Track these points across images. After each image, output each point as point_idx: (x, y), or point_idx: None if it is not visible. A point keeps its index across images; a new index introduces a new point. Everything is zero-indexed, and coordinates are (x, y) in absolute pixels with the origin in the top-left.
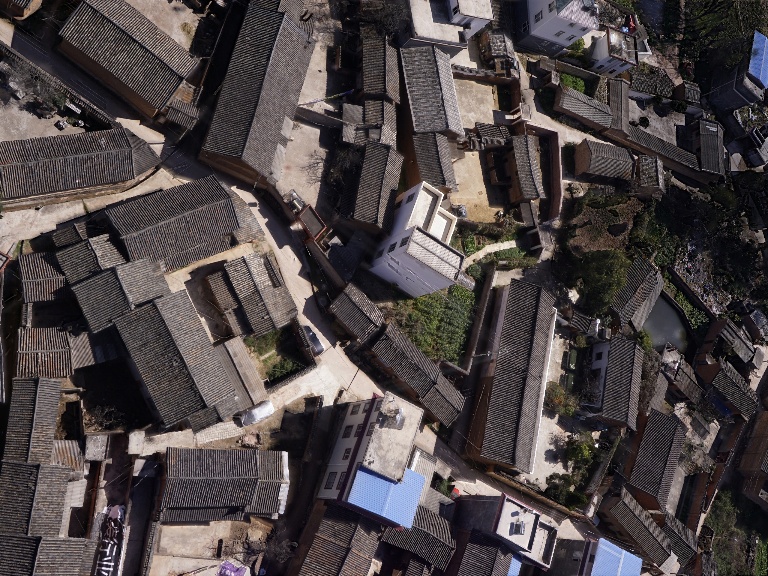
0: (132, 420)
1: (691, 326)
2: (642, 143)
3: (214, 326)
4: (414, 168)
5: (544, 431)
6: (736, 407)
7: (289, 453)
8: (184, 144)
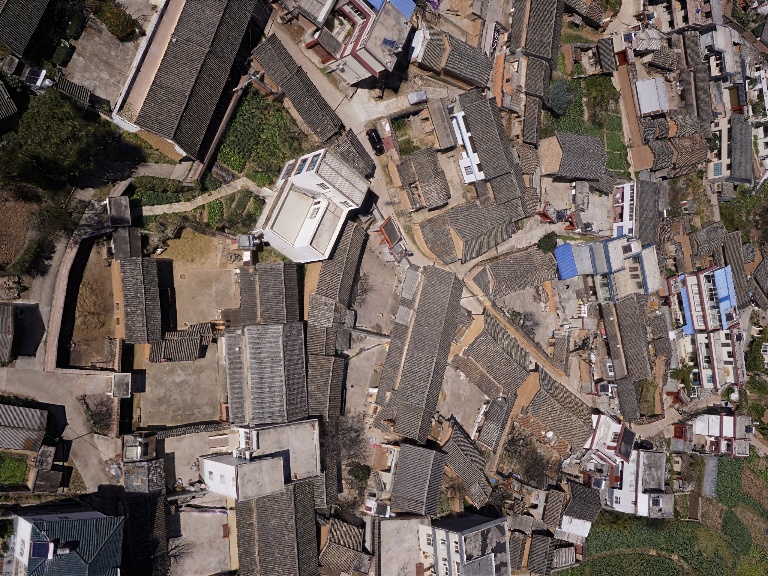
0: None
1: None
2: None
3: None
4: None
5: None
6: None
7: None
8: None
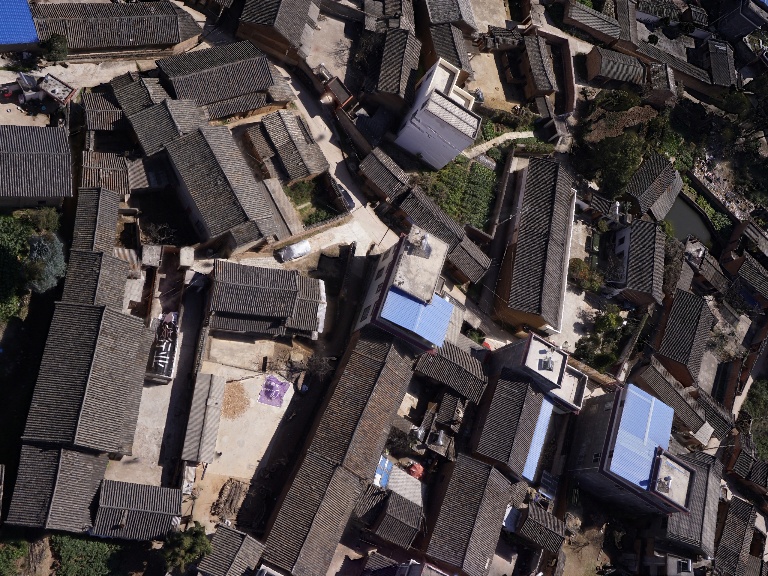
0: (183, 244)
1: (714, 228)
2: (652, 56)
3: (254, 175)
4: (432, 57)
5: (571, 305)
6: (764, 297)
7: (326, 291)
8: (223, 24)
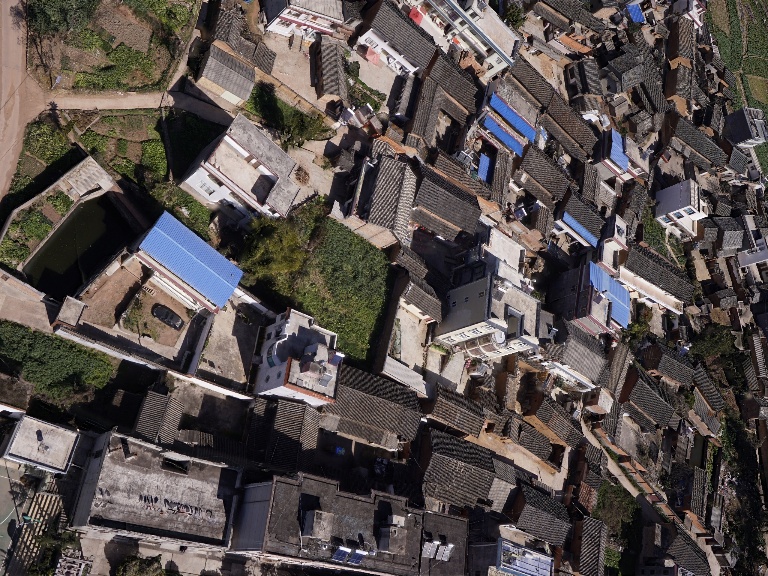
0: None
1: None
2: None
3: None
4: None
5: None
6: (692, 496)
7: None
8: None
